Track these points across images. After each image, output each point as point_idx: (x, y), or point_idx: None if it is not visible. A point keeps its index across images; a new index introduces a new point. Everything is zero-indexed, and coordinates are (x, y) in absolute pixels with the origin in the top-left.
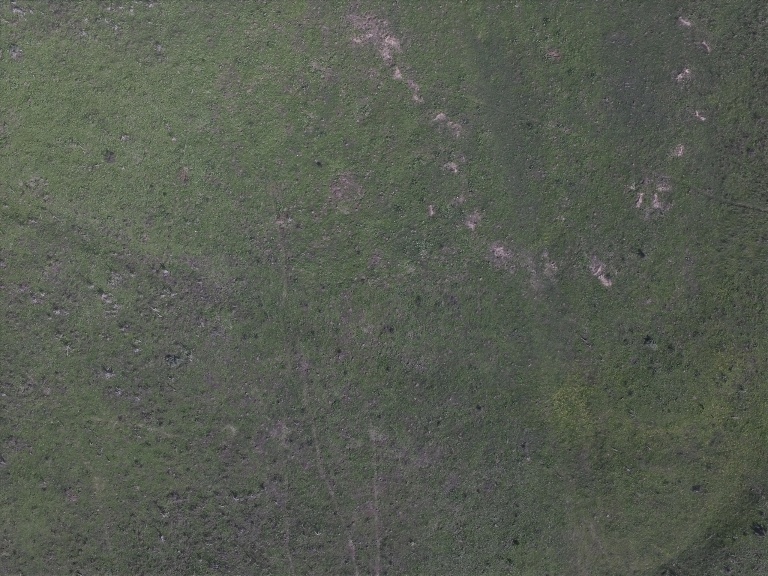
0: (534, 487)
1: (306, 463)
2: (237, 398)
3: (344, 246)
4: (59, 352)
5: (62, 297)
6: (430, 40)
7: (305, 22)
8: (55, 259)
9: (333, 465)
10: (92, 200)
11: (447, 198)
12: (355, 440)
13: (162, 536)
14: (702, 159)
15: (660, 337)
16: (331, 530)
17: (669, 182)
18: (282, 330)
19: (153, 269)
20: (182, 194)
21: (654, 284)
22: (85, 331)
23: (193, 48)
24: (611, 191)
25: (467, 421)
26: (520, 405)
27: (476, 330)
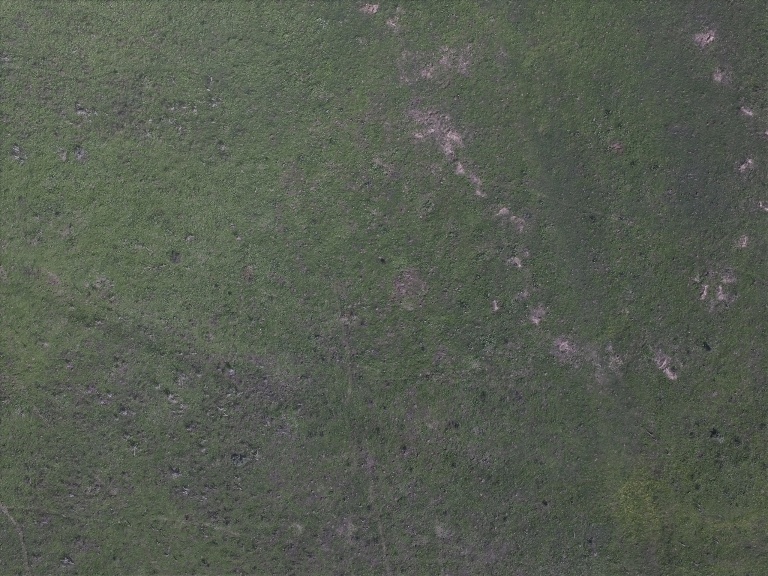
0: None
1: (372, 560)
2: (303, 496)
3: (408, 342)
4: (126, 452)
5: (129, 398)
6: (492, 134)
7: (367, 118)
8: (122, 360)
9: (399, 562)
10: (158, 301)
11: (511, 293)
12: (421, 537)
13: None
14: (766, 250)
15: (726, 430)
16: None
17: (733, 273)
18: (347, 427)
19: (219, 368)
20: (247, 293)
21: (720, 377)
22: (152, 431)
23: (256, 147)
24: (675, 283)
25: (533, 516)
26: (586, 500)
27: (542, 425)
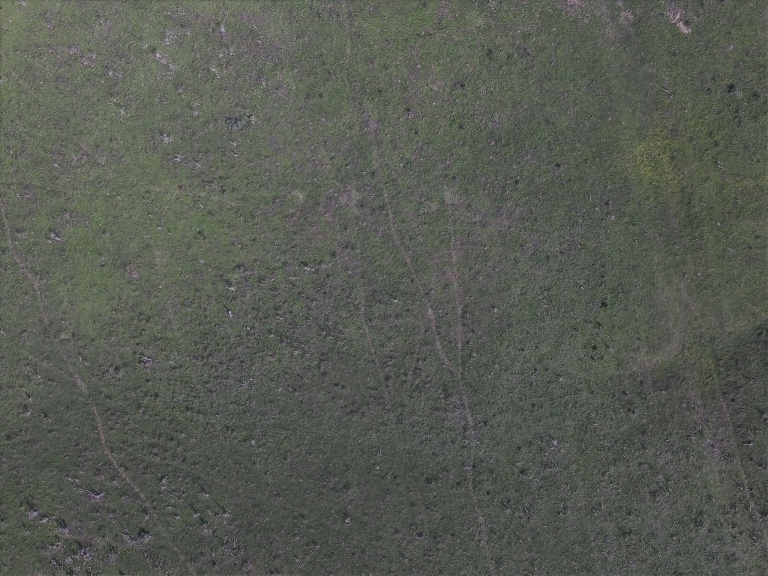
0: (620, 246)
1: (379, 230)
2: (303, 163)
3: None
4: (113, 118)
5: (114, 59)
6: None
7: None
8: (105, 18)
9: (407, 231)
10: None
11: None
12: (429, 204)
13: (230, 311)
14: None
15: (744, 86)
16: (409, 298)
17: None
18: (348, 90)
19: (209, 28)
20: None
21: (736, 29)
22: (140, 95)
23: None
24: None
25: (546, 180)
26: (601, 161)
27: (552, 83)
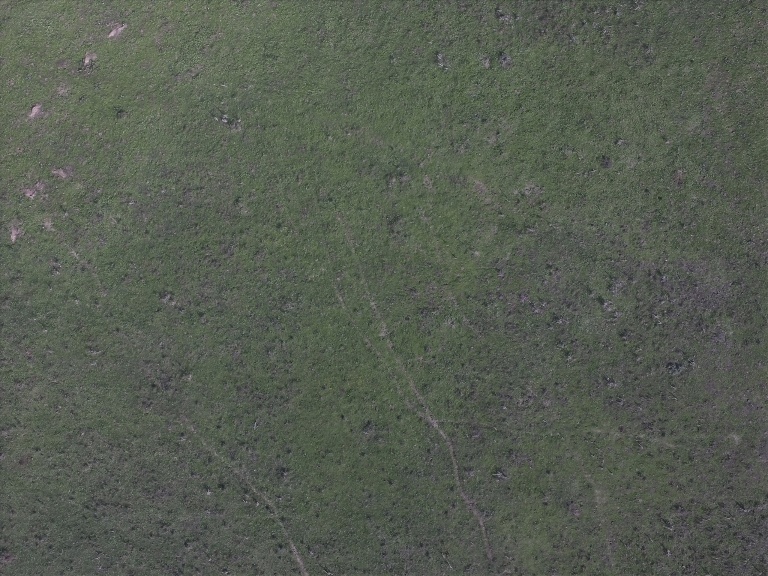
0: None
1: None
2: (739, 406)
3: None
4: (559, 363)
5: (561, 306)
6: None
7: None
8: (555, 268)
9: None
10: (589, 207)
11: None
12: None
13: (668, 550)
14: None
15: None
16: None
17: None
18: None
19: (650, 275)
20: (677, 198)
21: None
22: (585, 340)
23: (680, 49)
24: None
25: None
26: None
27: None
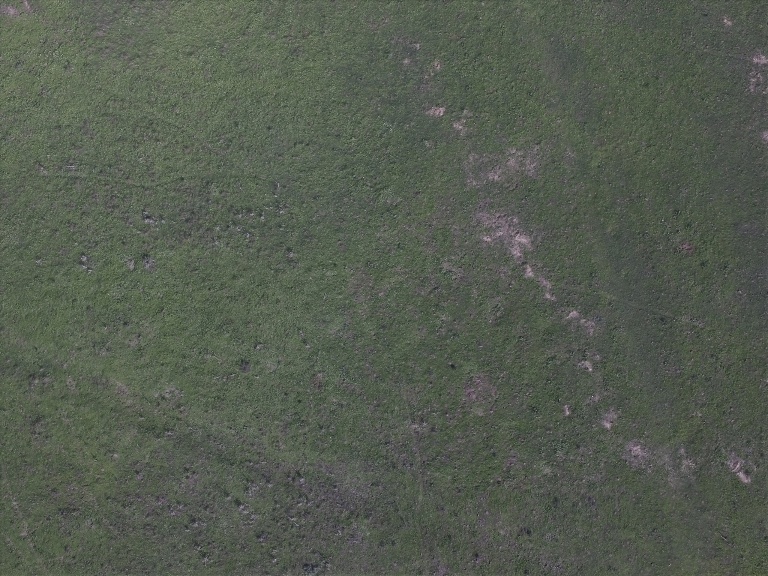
0: None
1: None
2: None
3: (479, 448)
4: (197, 563)
5: (199, 508)
6: (560, 236)
7: (435, 222)
8: (192, 471)
9: None
10: (228, 410)
11: (582, 397)
12: None
13: None
14: None
15: None
16: None
17: None
18: (419, 535)
19: (289, 477)
20: (316, 401)
21: None
22: (222, 542)
23: (324, 253)
24: (747, 385)
25: None
26: None
27: (615, 531)
